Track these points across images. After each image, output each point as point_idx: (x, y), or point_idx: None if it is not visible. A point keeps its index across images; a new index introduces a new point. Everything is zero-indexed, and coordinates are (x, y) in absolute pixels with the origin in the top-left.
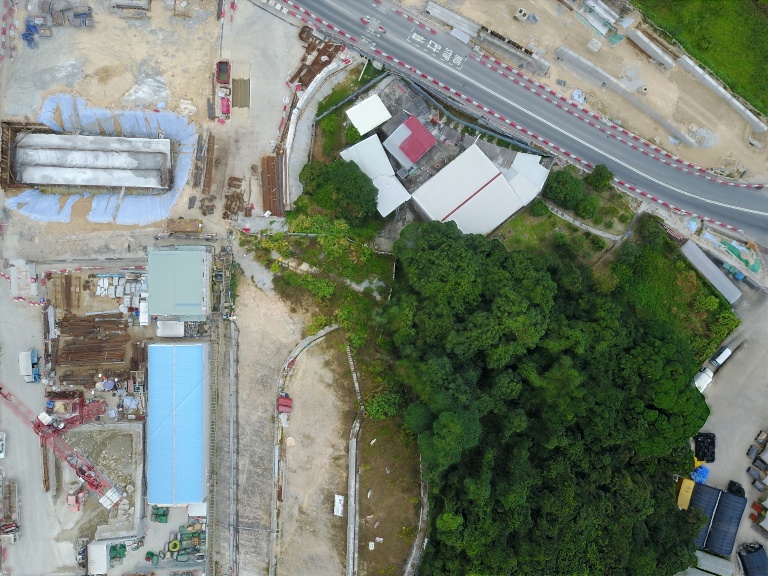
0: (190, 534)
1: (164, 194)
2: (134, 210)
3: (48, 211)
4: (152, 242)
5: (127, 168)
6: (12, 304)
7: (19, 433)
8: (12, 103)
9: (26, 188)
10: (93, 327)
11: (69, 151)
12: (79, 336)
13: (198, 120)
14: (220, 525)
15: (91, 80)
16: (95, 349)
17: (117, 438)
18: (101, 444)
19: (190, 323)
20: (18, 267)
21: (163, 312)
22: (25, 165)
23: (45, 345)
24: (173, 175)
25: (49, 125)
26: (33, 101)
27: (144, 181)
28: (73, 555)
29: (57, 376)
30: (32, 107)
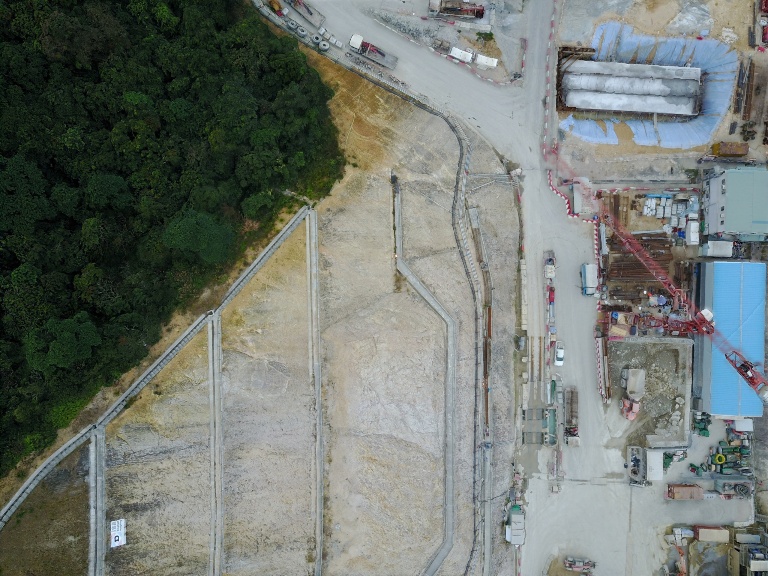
0: (731, 449)
1: (691, 121)
2: (673, 135)
3: (594, 134)
4: (694, 165)
5: (661, 95)
6: (565, 221)
7: (572, 343)
8: (566, 29)
9: (571, 111)
10: (641, 245)
11: (608, 77)
12: (628, 253)
13: (739, 48)
14: (759, 442)
15: (639, 8)
16: (644, 266)
17: (663, 353)
18: (653, 357)
19: (736, 244)
20: (583, 184)
21: (740, 229)
22: (572, 89)
23: (598, 260)
24: (701, 103)
25: (595, 51)
26: (585, 27)
27: (675, 108)
28: (621, 462)
29: (608, 291)
30: (584, 33)
